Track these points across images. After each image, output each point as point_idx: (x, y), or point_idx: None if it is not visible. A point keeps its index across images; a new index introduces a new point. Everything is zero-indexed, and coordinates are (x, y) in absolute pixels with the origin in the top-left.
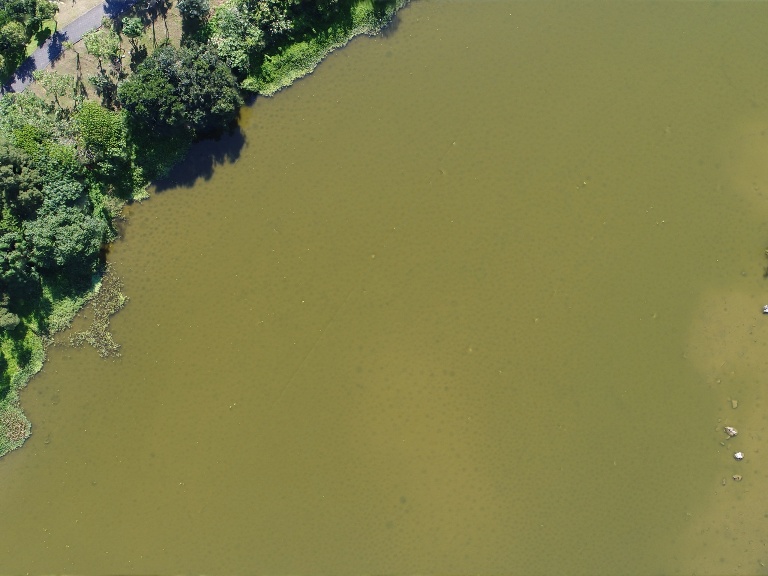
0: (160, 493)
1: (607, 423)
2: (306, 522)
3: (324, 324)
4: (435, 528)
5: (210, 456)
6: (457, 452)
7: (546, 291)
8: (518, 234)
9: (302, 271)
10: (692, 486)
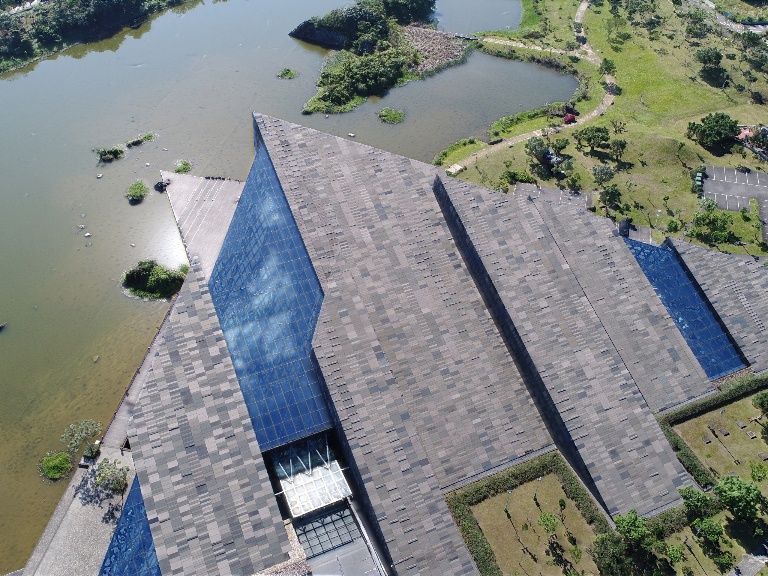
0: None
1: None
2: None
3: None
4: None
5: None
6: None
7: None
8: None
9: None
10: (56, 257)
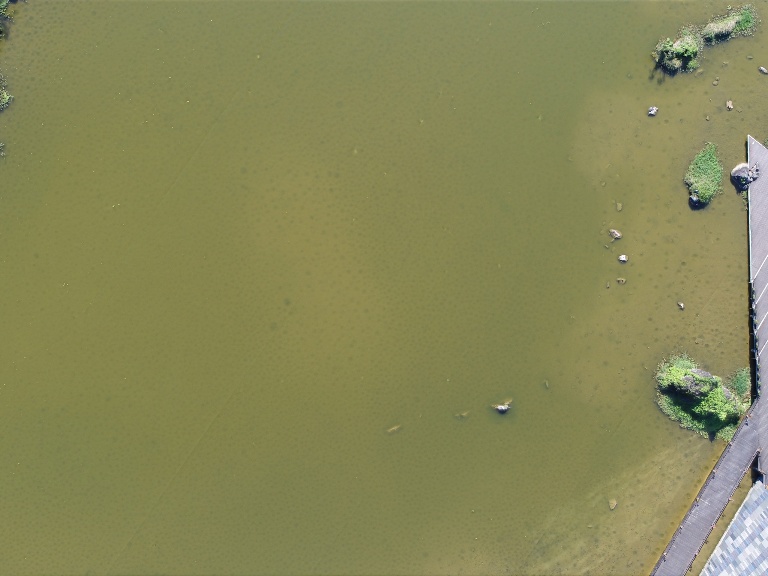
0: (44, 294)
1: (492, 226)
2: (190, 323)
3: (209, 124)
4: (319, 330)
5: (94, 257)
6: (341, 254)
7: (431, 92)
8: (404, 35)
9: (187, 71)
10: (576, 289)
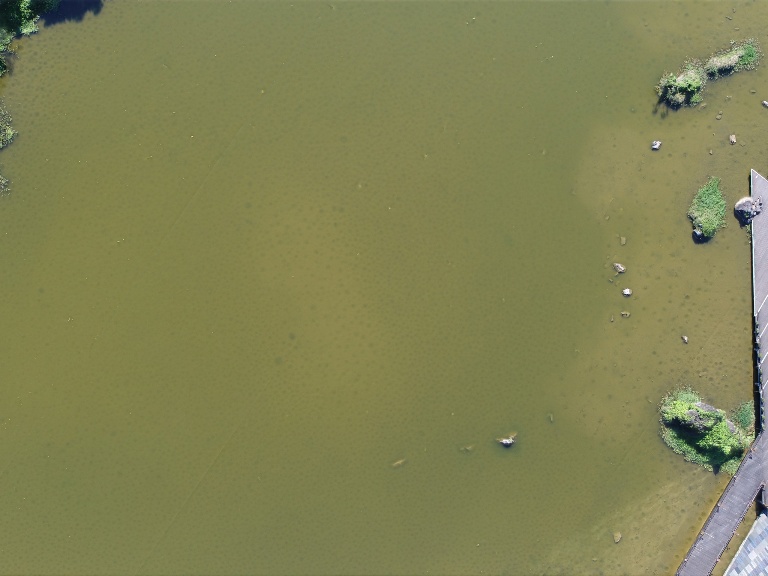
0: (49, 329)
1: (496, 260)
2: (195, 358)
3: (213, 159)
4: (324, 364)
5: (99, 292)
6: (346, 288)
7: (435, 127)
8: (408, 70)
9: (191, 106)
10: (580, 323)
